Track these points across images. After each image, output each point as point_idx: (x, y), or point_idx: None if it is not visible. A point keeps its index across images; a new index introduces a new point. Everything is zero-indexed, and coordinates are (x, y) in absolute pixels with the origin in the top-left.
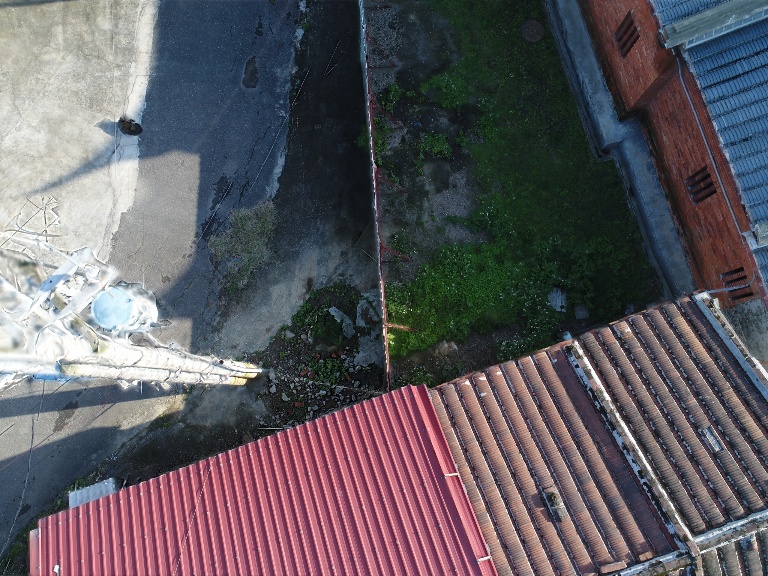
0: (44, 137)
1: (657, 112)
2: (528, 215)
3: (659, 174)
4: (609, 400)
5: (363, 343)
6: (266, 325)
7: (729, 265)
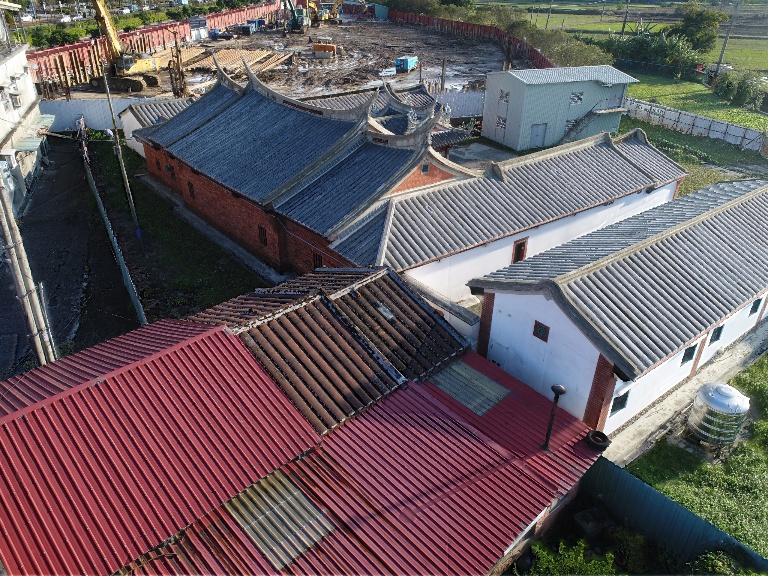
0: None
1: (292, 258)
2: None
3: None
4: None
5: None
6: None
7: None
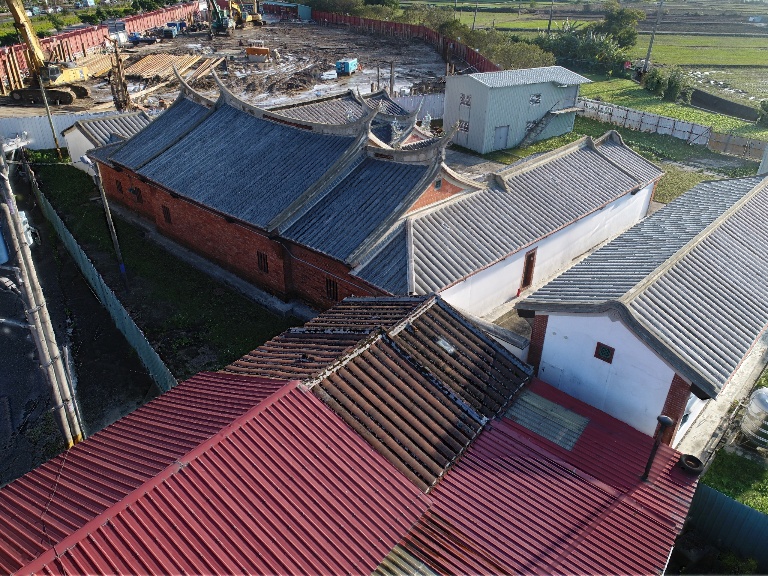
0: None
1: (298, 285)
2: None
3: (319, 311)
4: None
5: None
6: None
7: None
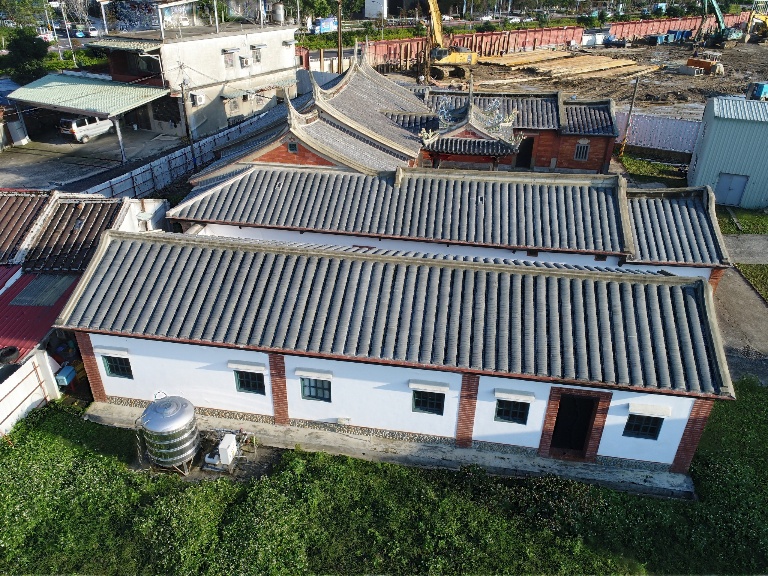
0: (29, 181)
1: None
2: None
3: None
4: None
5: None
6: None
7: None
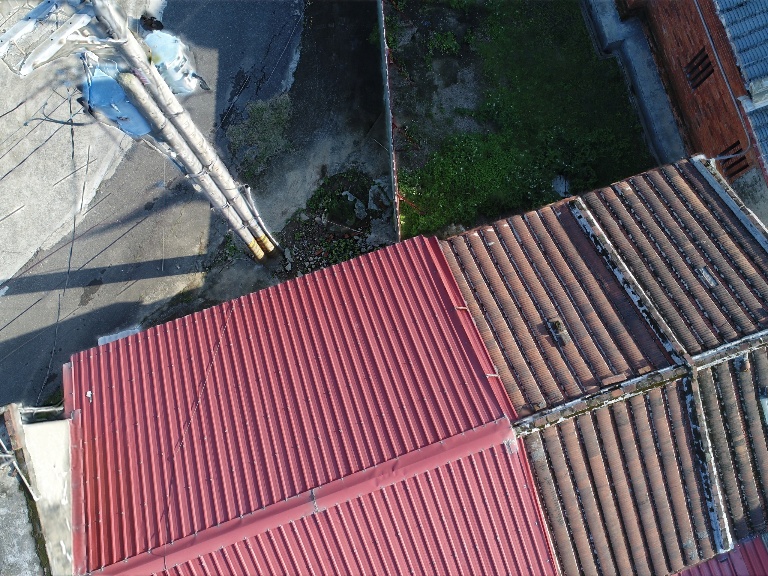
0: None
1: (657, 6)
2: (533, 108)
3: (659, 70)
4: (610, 245)
5: (375, 225)
6: (282, 208)
7: (726, 143)
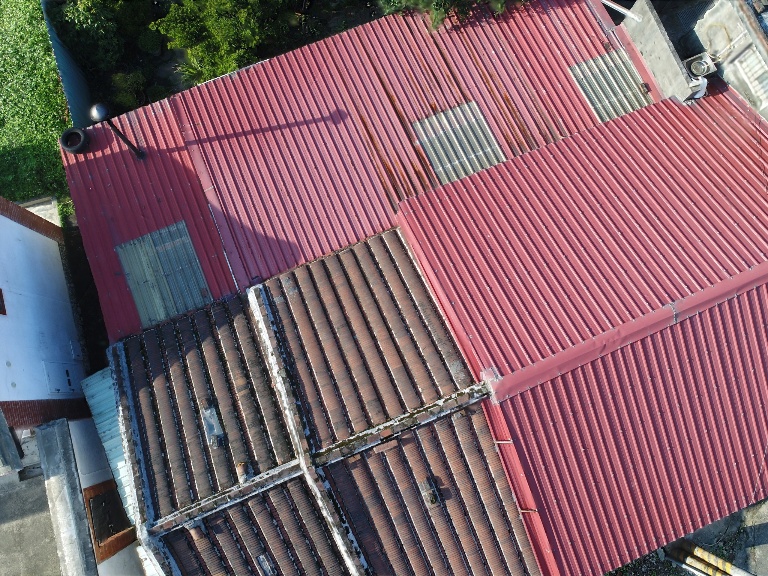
0: None
1: None
2: None
3: None
4: None
5: None
6: None
7: None
